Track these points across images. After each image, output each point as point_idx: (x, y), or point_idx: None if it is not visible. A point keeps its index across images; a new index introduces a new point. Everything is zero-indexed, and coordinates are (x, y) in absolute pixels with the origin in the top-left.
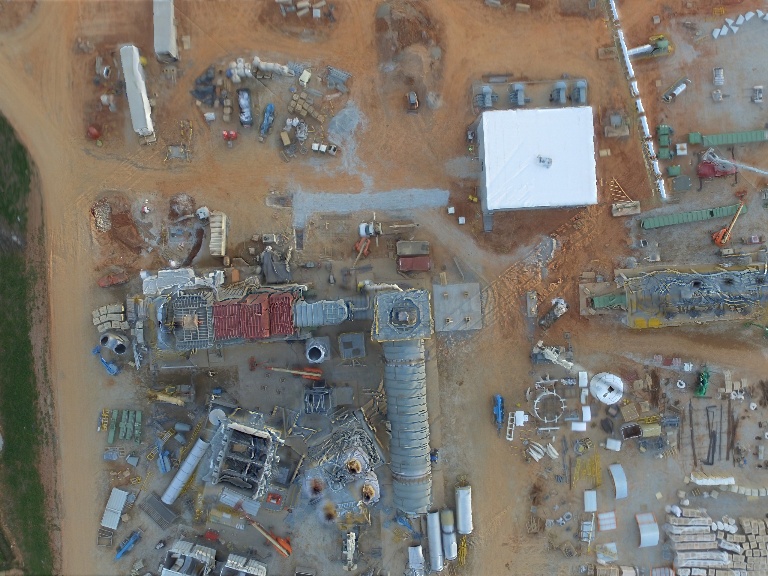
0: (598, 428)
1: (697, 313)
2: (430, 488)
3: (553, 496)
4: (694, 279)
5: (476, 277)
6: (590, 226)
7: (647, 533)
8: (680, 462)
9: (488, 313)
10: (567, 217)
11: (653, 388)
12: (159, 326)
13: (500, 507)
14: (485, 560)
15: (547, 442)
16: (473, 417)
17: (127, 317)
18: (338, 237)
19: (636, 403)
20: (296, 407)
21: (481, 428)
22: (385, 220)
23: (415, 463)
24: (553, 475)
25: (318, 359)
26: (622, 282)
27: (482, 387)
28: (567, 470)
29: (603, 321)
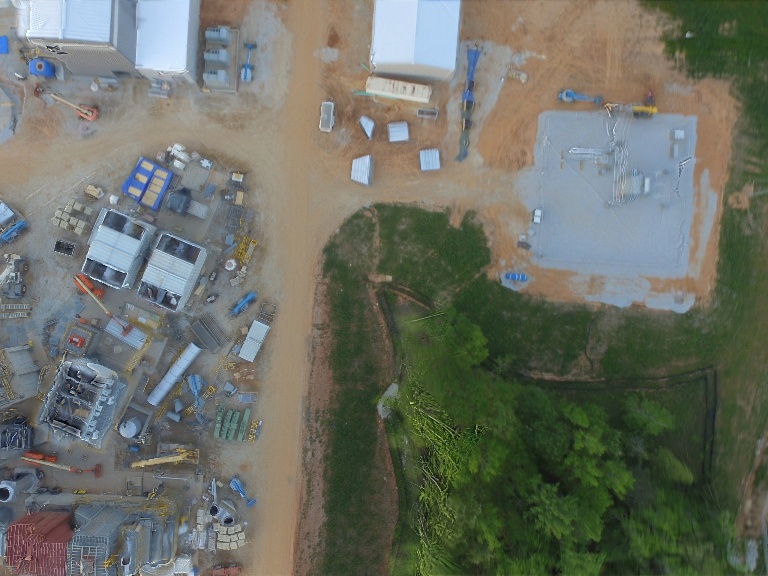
0: None
1: None
2: None
3: None
4: None
5: None
6: None
7: None
8: None
9: None
10: None
11: None
12: None
13: None
14: None
15: None
16: None
17: None
18: None
19: None
20: None
21: None
22: None
23: None
24: None
25: (1, 489)
26: None
27: None
28: None
29: None
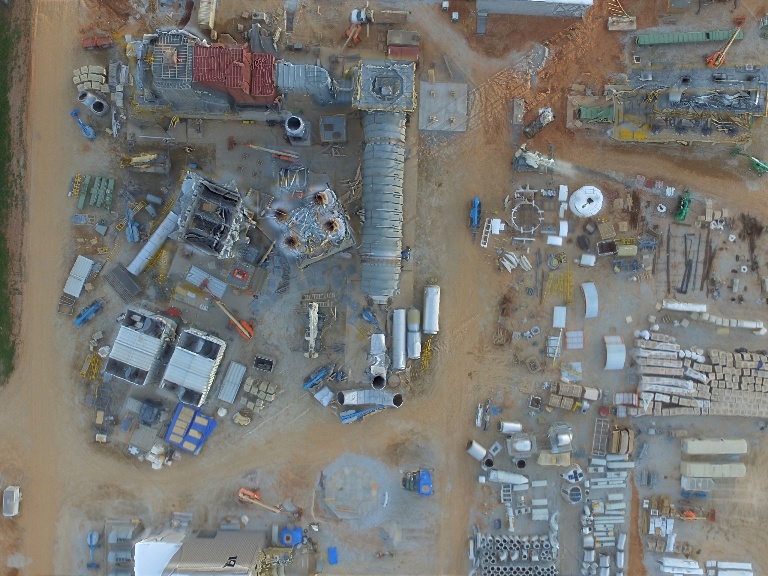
0: (574, 244)
1: (684, 128)
2: (398, 275)
3: (522, 309)
4: (684, 96)
5: (465, 78)
6: (584, 38)
7: (614, 353)
8: (653, 288)
9: (473, 116)
10: (562, 26)
11: (633, 209)
12: (138, 62)
13: (468, 315)
14: (448, 367)
15: (521, 253)
16: (449, 220)
17: (108, 82)
18: (329, 23)
19: (614, 223)
20: (271, 191)
21: (456, 232)
22: (378, 10)
23: (385, 243)
24: (524, 288)
25: (297, 129)
26: (611, 94)
27: (461, 191)
28: (539, 284)
29: (589, 136)
